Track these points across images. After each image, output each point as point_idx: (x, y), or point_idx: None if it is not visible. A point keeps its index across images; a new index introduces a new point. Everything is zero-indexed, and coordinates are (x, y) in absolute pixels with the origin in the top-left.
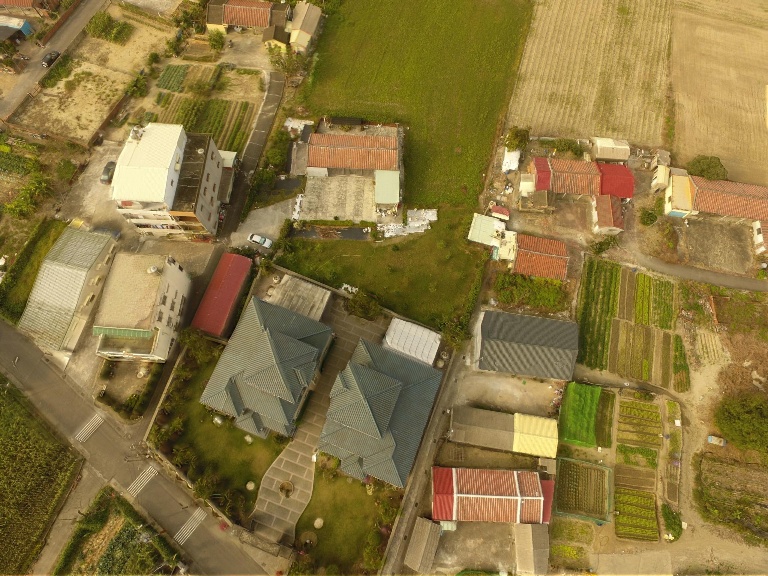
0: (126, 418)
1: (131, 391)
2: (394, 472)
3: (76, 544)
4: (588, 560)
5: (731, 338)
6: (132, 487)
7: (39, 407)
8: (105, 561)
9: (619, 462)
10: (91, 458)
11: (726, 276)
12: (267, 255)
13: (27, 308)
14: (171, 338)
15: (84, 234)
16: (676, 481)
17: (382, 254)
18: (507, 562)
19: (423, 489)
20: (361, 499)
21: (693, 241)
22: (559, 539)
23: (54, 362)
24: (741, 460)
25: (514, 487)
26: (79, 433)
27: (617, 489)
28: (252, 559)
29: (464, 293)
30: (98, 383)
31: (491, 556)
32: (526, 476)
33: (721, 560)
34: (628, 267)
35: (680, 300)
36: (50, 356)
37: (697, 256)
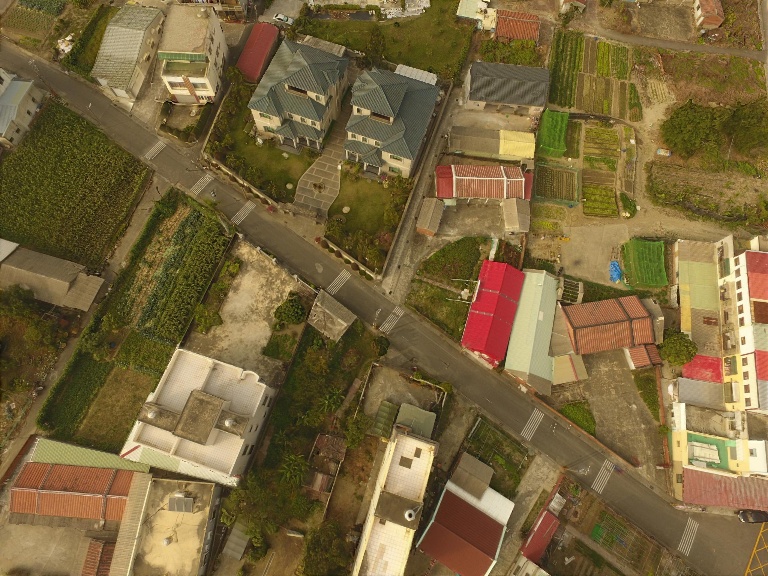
0: (185, 140)
1: (187, 124)
2: (405, 148)
3: (154, 223)
4: (562, 230)
5: (676, 85)
6: (194, 188)
7: (113, 136)
8: (178, 234)
9: (585, 168)
10: (159, 169)
11: (672, 42)
12: (290, 27)
13: (97, 60)
14: (217, 81)
15: (138, 8)
16: (631, 179)
17: (386, 31)
18: (498, 232)
19: (428, 187)
20: (379, 193)
21: (644, 18)
22: (539, 217)
23: (121, 106)
24: (684, 165)
25: (501, 173)
26: (147, 154)
27: (584, 184)
28: (295, 233)
29: (455, 56)
30: (159, 120)
31: (485, 229)
32: (510, 169)
33: (668, 230)
34: (590, 37)
35: (634, 59)
36: (117, 102)
37: (648, 29)
